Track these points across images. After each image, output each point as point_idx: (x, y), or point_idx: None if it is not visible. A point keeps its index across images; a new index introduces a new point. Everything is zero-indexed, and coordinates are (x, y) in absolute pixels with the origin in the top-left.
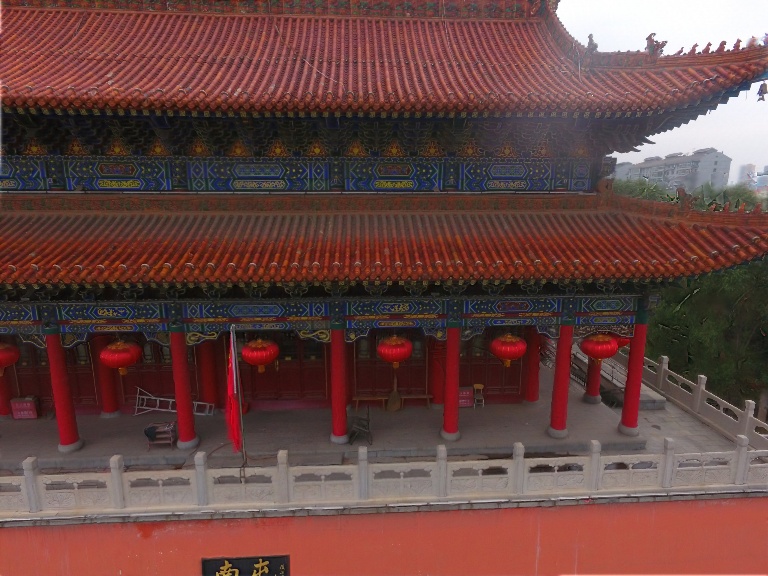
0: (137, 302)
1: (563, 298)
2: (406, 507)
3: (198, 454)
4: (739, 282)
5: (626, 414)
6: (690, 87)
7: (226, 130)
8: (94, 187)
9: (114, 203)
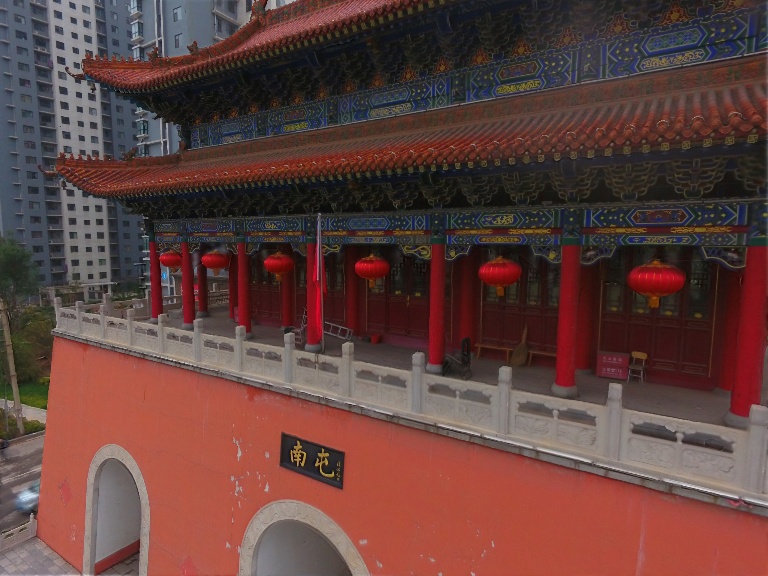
0: (287, 216)
1: (750, 202)
2: (456, 433)
3: None
4: None
5: None
6: None
7: (364, 63)
8: (281, 132)
9: (289, 142)
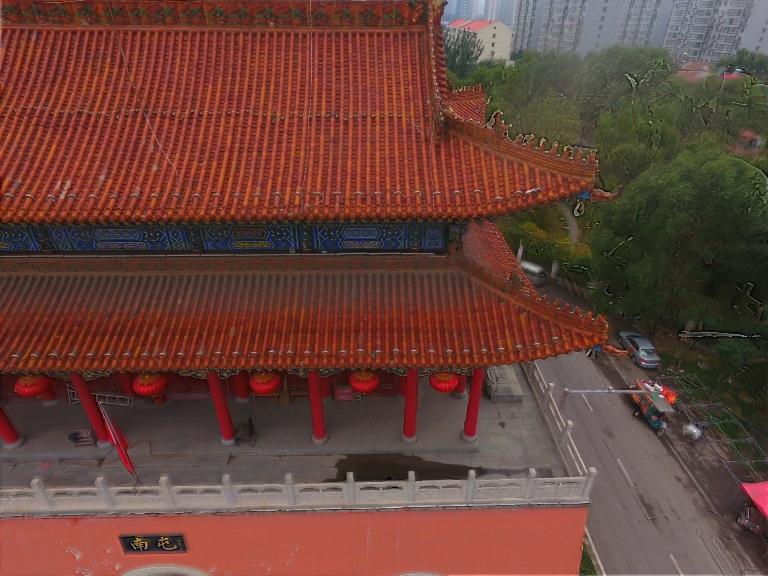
0: None
1: None
2: (264, 512)
3: (97, 480)
4: (681, 225)
5: (466, 426)
6: (514, 195)
7: None
8: None
9: None
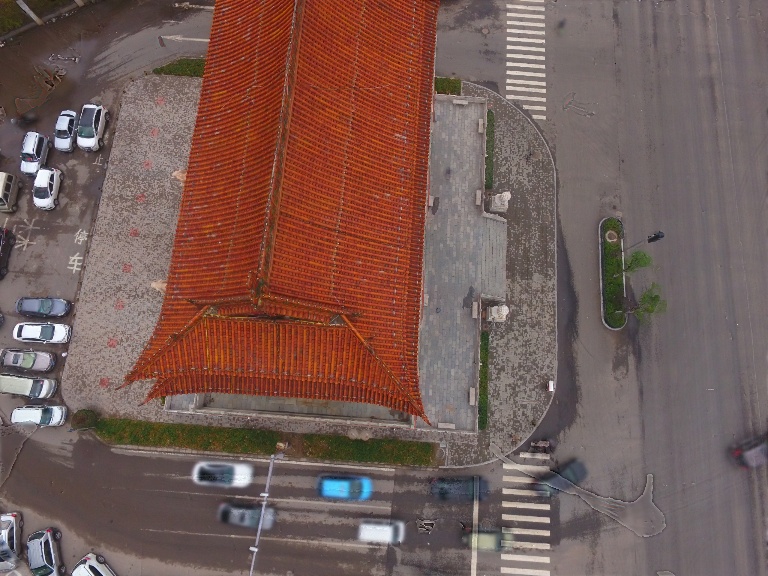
0: None
1: None
2: None
3: None
4: None
5: None
6: None
7: None
8: None
9: None
